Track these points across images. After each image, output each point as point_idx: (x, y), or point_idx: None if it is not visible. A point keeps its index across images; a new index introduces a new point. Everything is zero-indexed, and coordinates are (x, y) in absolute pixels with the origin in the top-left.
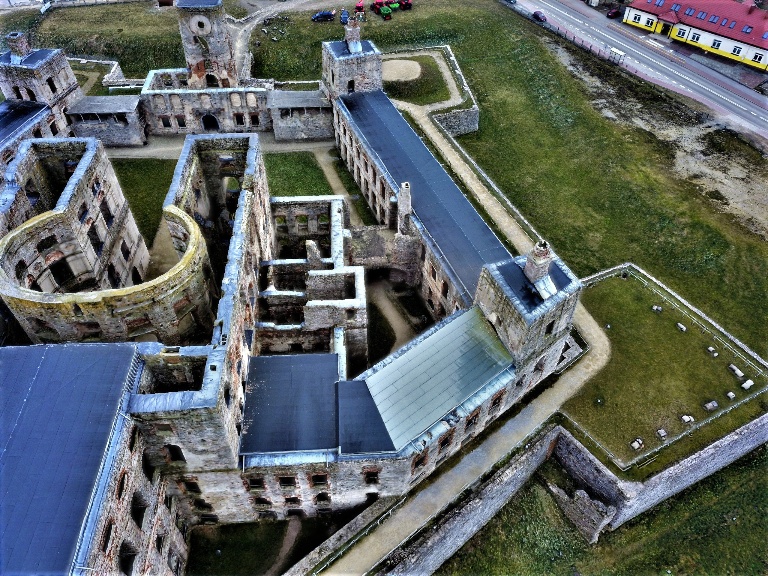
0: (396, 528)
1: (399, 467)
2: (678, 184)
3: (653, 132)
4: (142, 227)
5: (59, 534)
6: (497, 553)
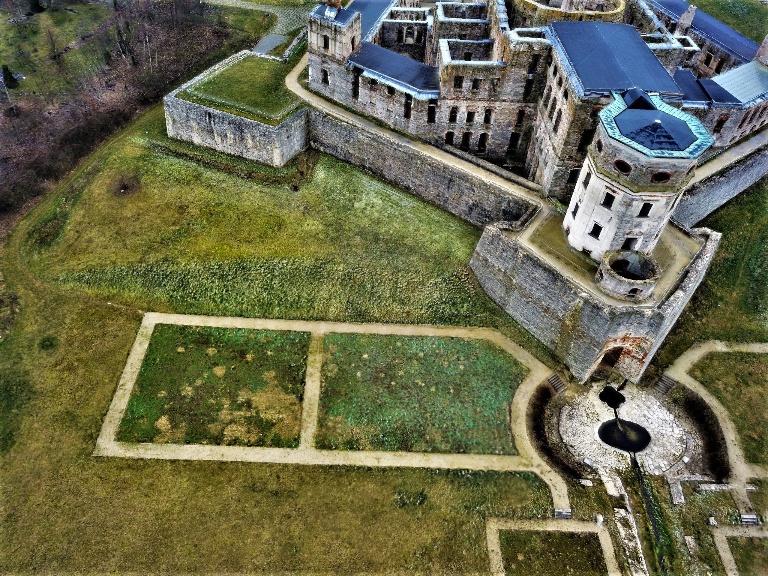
0: (727, 158)
1: (738, 117)
2: None
3: None
4: None
5: None
6: (765, 194)
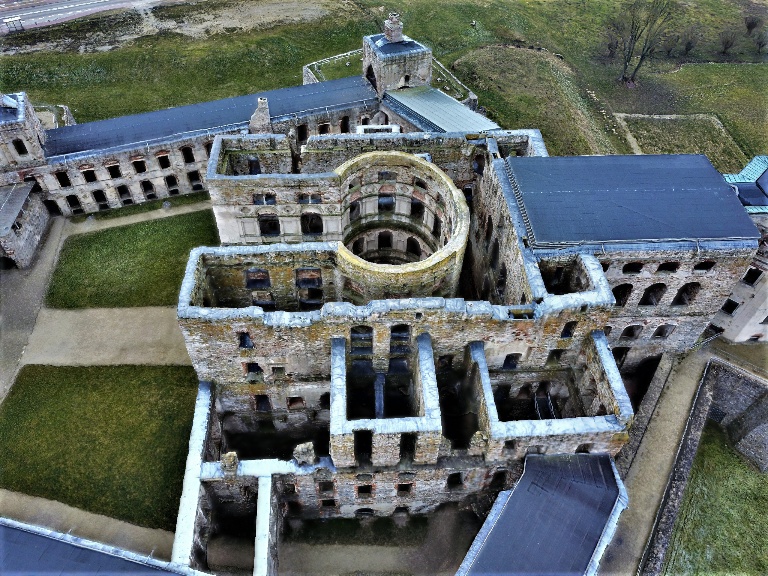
0: None
1: None
2: (214, 40)
3: (144, 35)
4: (167, 382)
5: (644, 161)
6: None
